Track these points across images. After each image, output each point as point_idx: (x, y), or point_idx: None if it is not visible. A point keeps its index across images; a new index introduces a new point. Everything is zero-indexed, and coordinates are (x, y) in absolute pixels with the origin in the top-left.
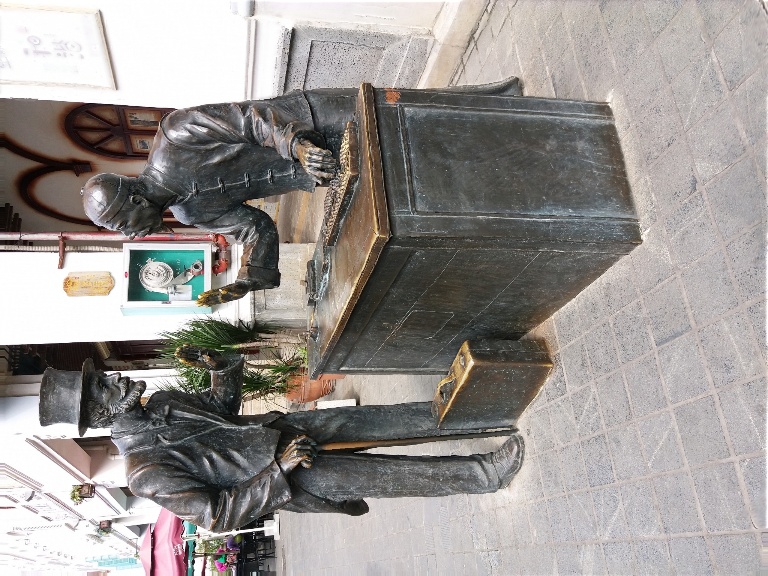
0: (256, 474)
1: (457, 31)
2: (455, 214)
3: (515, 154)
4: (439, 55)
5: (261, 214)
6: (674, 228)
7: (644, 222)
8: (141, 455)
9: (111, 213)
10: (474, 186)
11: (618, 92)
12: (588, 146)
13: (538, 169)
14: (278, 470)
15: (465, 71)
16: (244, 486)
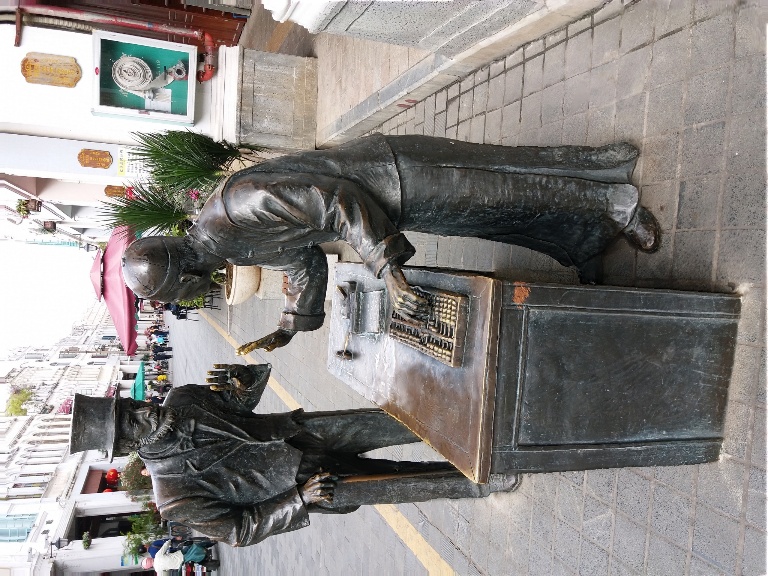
0: (277, 494)
1: (576, 6)
2: (555, 448)
3: (630, 368)
4: (542, 18)
5: (313, 250)
6: (759, 484)
7: (728, 445)
8: (171, 484)
9: (158, 296)
10: (581, 412)
11: (757, 294)
12: (704, 352)
13: (648, 386)
14: (301, 503)
15: (567, 46)
16: (267, 512)
